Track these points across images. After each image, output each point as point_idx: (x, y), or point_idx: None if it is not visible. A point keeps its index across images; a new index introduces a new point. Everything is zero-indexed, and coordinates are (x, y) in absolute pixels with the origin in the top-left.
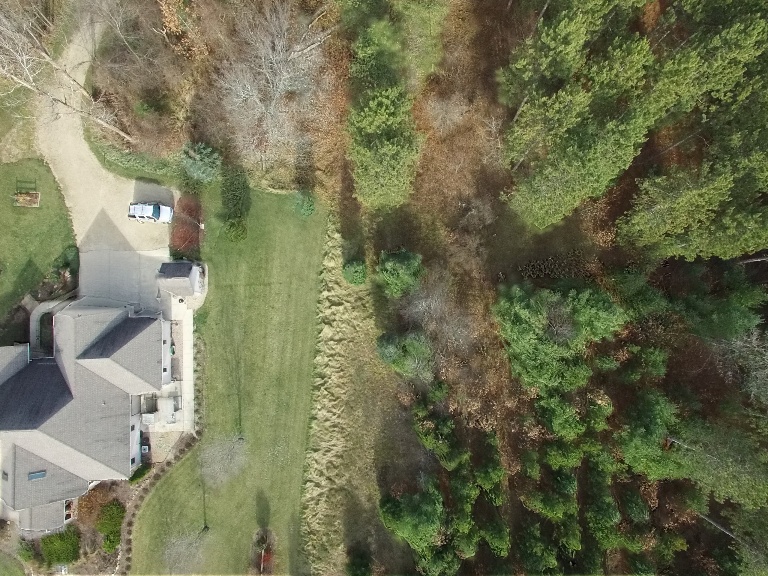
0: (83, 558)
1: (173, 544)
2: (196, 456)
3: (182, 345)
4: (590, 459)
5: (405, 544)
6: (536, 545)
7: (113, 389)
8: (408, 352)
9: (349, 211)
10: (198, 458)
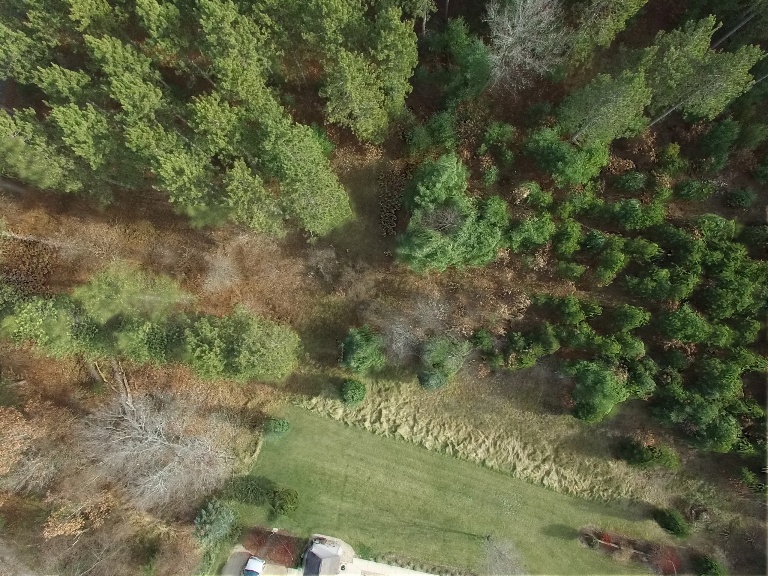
0: None
1: None
2: None
3: (386, 575)
4: (576, 213)
5: (620, 402)
6: (646, 284)
7: None
8: (440, 363)
9: (293, 384)
10: None
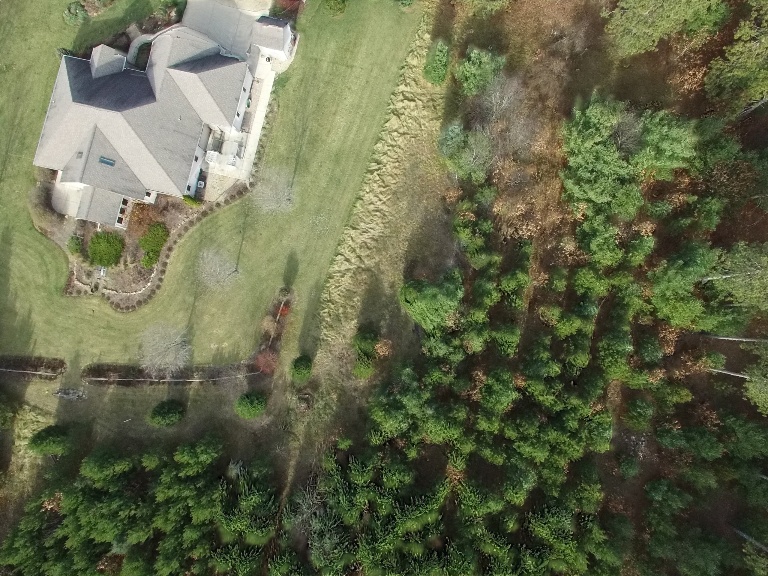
0: (122, 264)
1: (203, 278)
2: (244, 205)
3: (258, 102)
4: (617, 295)
5: (415, 335)
6: (544, 352)
7: (190, 110)
8: (468, 145)
9: (444, 16)
10: (246, 207)
